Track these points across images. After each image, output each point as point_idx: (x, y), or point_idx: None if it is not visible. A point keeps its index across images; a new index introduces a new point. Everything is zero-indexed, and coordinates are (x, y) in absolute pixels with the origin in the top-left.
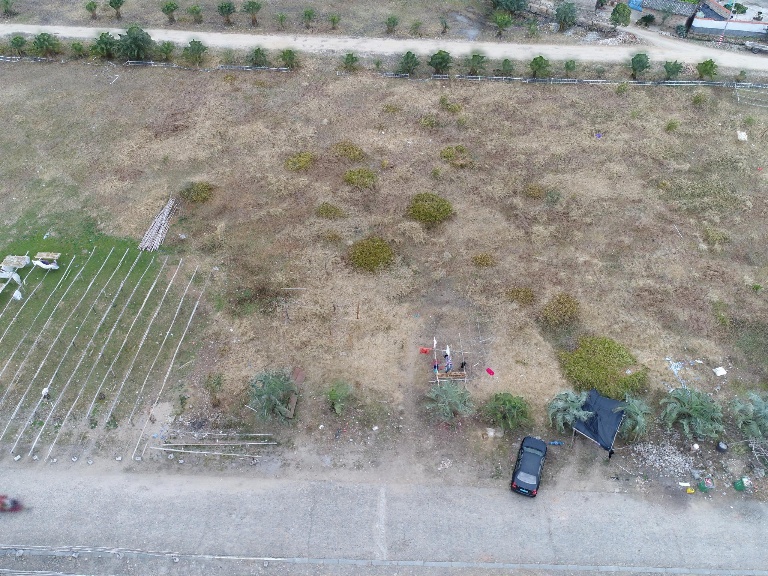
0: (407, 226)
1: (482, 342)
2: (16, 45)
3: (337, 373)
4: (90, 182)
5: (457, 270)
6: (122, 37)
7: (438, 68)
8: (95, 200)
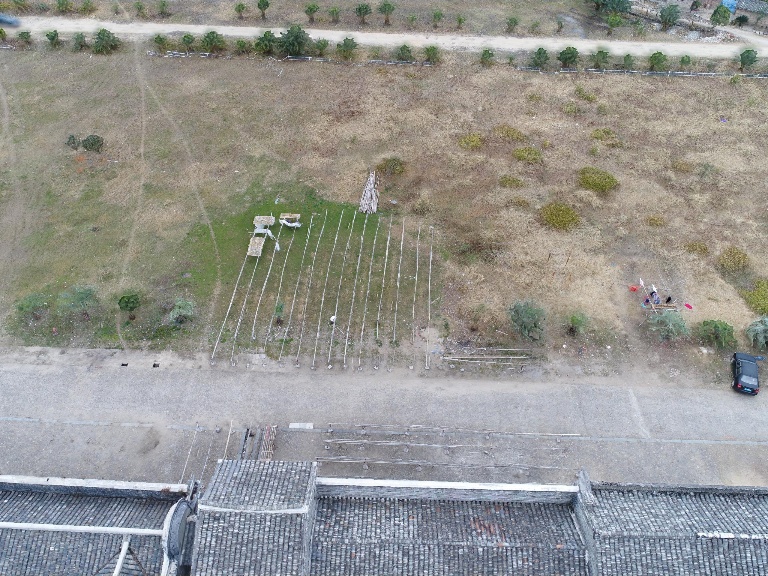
0: (583, 194)
1: (675, 284)
2: (187, 42)
3: (563, 307)
4: (295, 158)
5: (636, 229)
6: (285, 35)
7: (566, 62)
8: (306, 173)
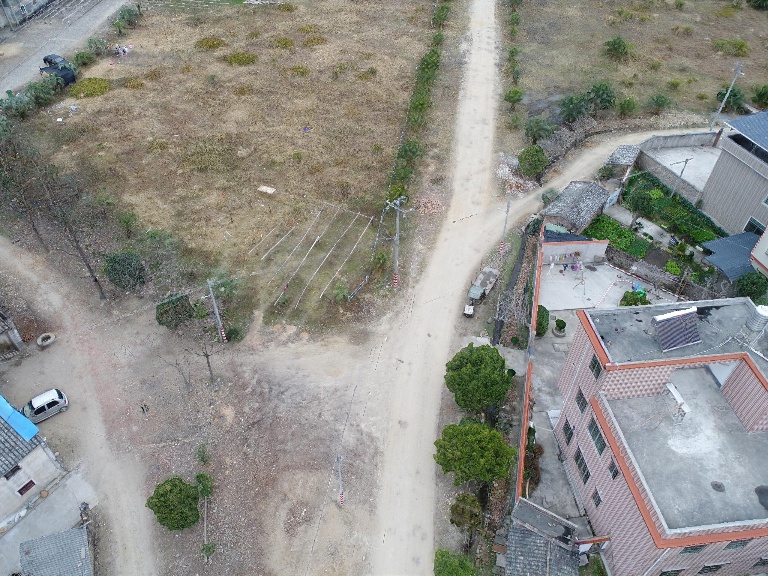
0: (227, 51)
1: None
2: None
3: None
4: None
5: None
6: None
7: None
8: None
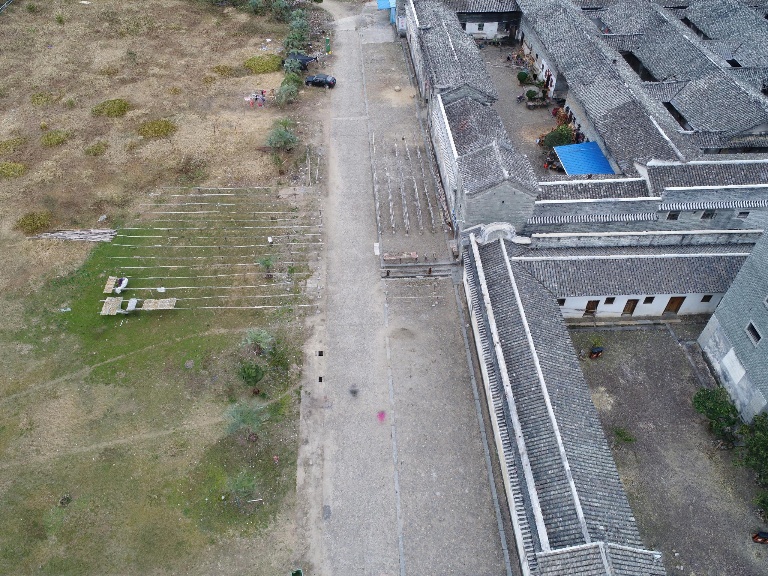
0: (131, 115)
1: None
2: None
3: (261, 135)
4: None
5: (181, 99)
6: None
7: None
8: (12, 292)
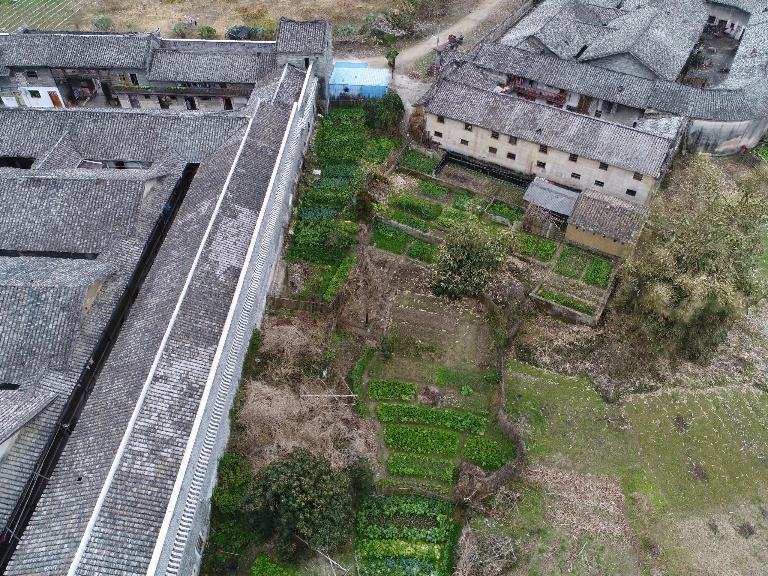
0: None
1: None
2: None
3: (139, 28)
4: None
5: (216, 3)
6: None
7: None
8: None
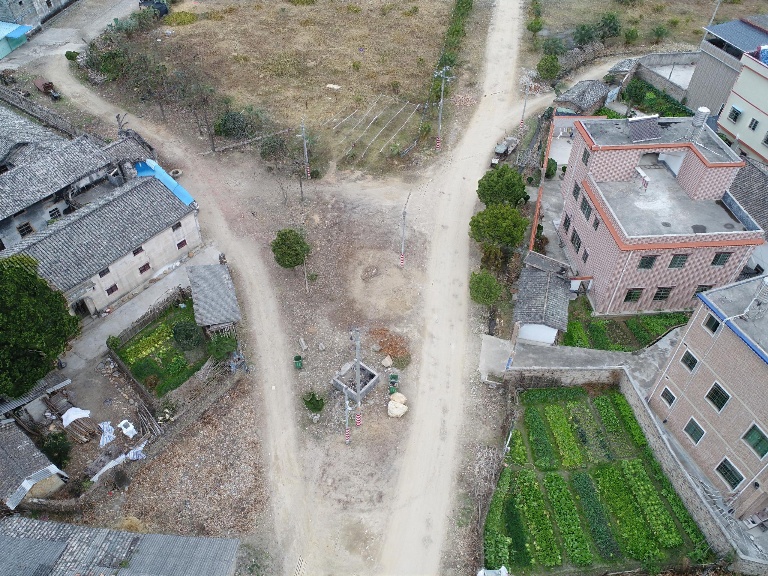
0: None
1: None
2: None
3: None
4: None
5: None
6: None
7: None
8: None
